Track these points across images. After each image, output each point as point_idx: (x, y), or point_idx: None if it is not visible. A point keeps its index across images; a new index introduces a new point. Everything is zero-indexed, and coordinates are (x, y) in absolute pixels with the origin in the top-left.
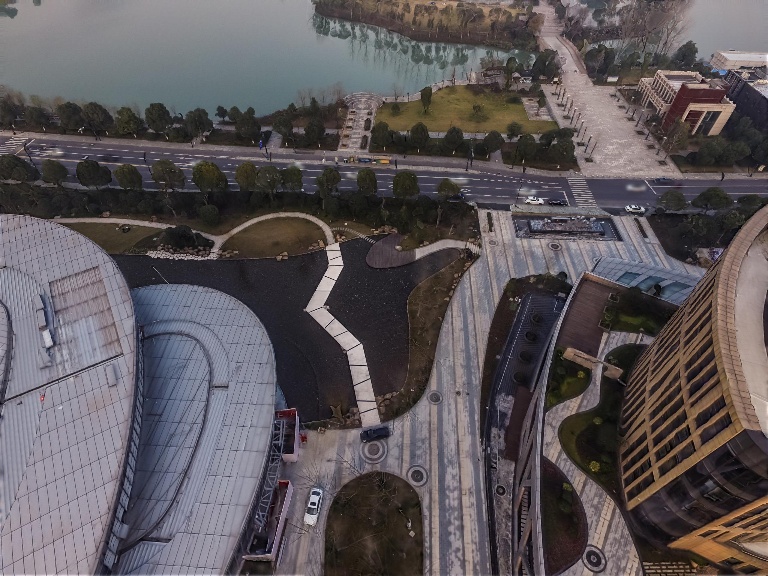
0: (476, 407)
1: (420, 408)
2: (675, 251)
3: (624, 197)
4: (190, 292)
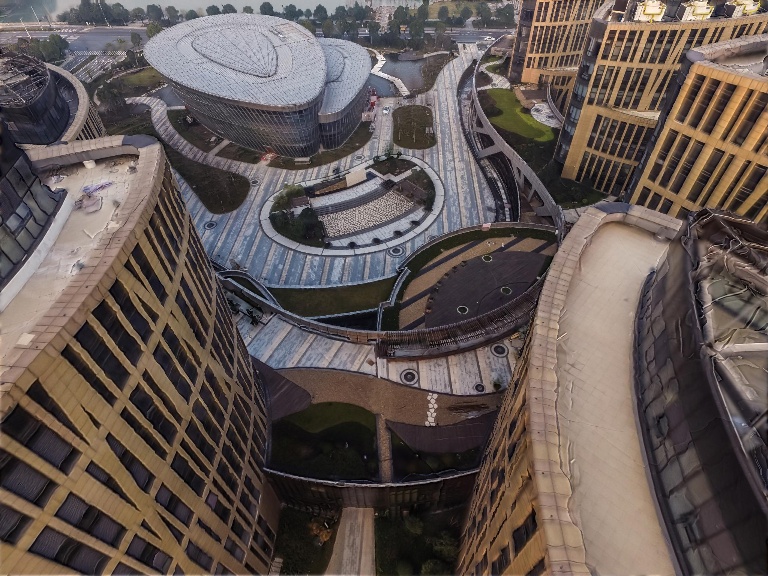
0: (455, 91)
1: (429, 92)
2: None
3: None
4: (325, 39)
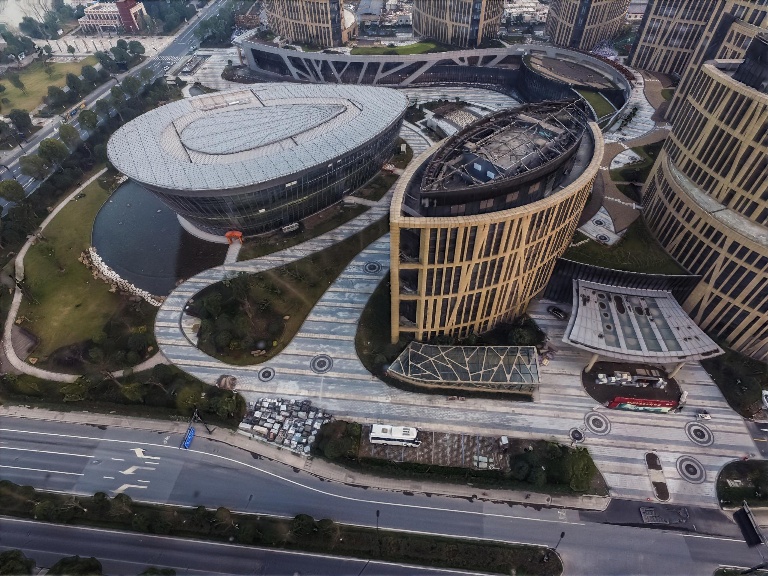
0: None
1: None
2: (227, 45)
3: (181, 50)
4: None
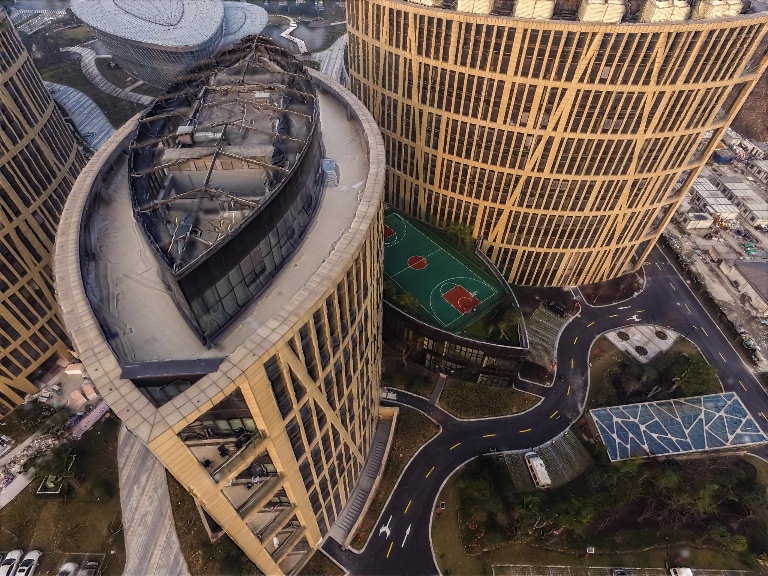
0: None
1: None
2: None
3: None
4: (235, 2)
